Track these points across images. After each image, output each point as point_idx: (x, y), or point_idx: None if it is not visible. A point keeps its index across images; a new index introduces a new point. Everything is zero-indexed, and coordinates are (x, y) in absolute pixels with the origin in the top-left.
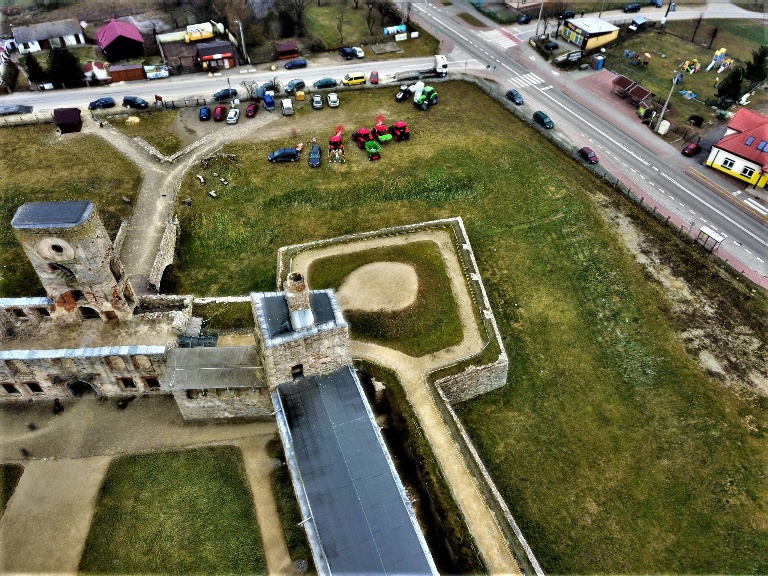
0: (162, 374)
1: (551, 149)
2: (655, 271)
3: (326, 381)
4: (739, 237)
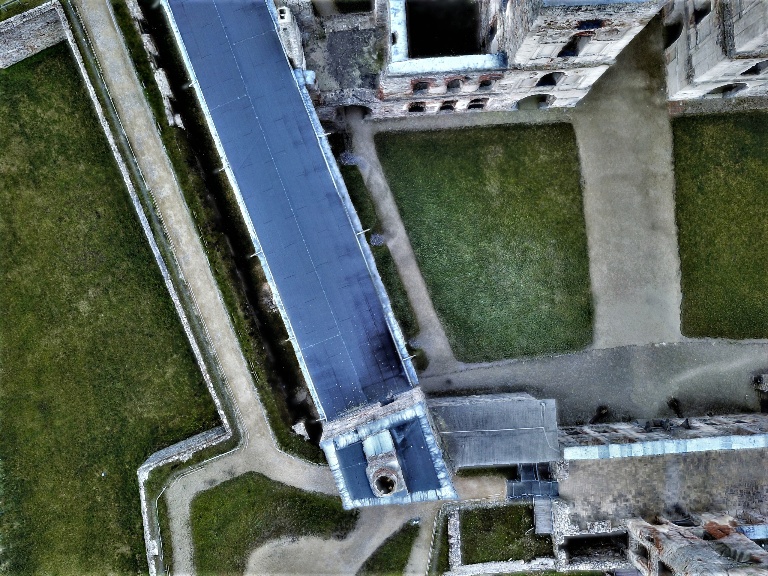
0: None
1: None
2: None
3: (353, 397)
4: None
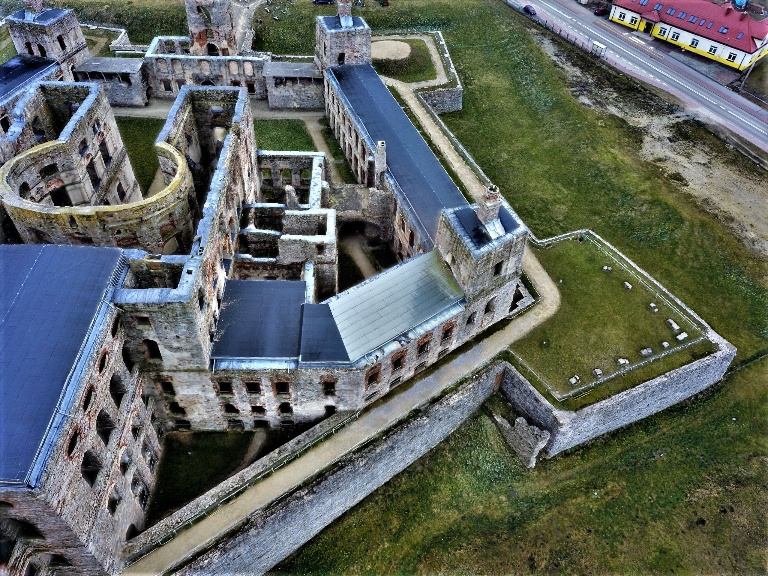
0: (258, 79)
1: (505, 7)
2: (561, 63)
3: (357, 67)
4: (620, 53)
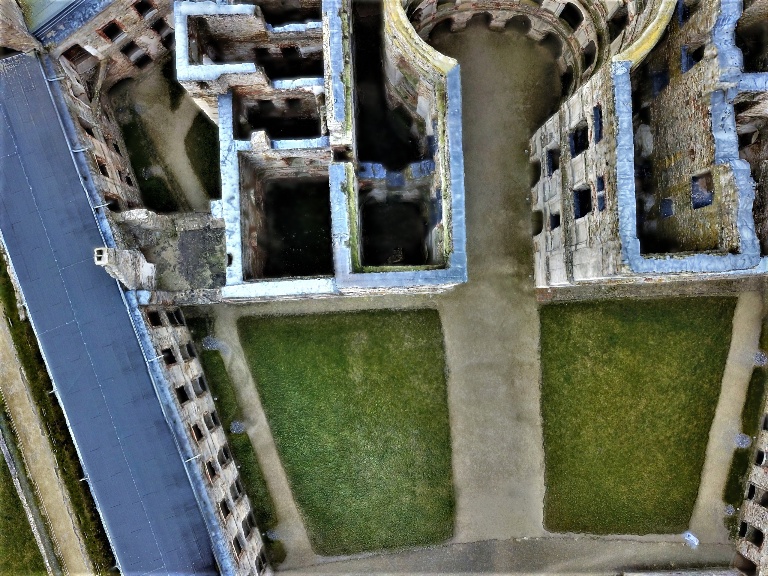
0: None
1: None
2: None
3: None
4: None
